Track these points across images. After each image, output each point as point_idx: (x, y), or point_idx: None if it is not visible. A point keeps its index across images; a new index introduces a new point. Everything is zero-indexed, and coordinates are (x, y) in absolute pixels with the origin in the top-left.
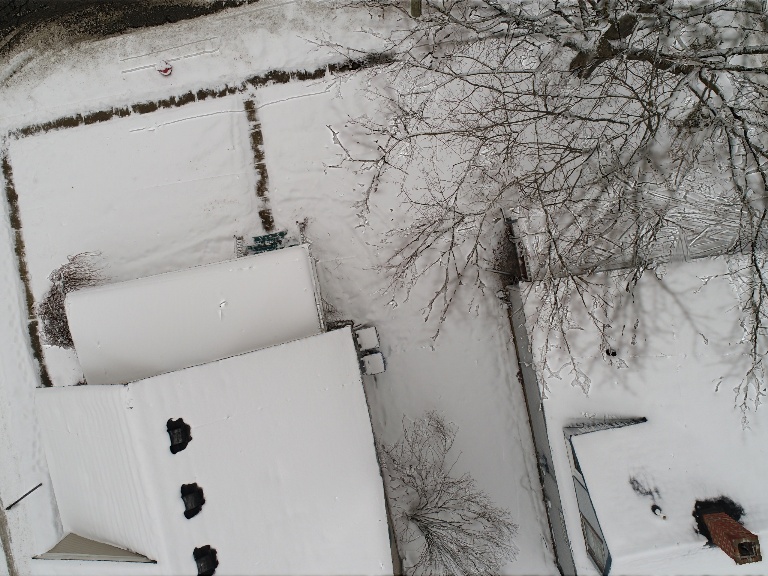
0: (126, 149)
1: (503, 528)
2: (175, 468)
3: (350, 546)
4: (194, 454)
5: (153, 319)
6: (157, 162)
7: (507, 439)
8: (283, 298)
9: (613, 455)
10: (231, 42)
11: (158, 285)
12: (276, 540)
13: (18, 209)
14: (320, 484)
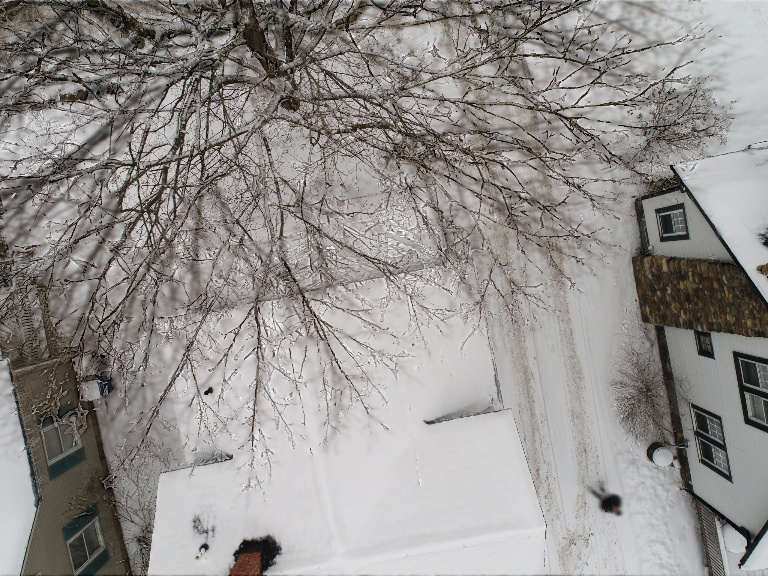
0: None
1: None
2: None
3: None
4: None
5: None
6: None
7: None
8: None
9: (187, 493)
10: None
11: None
12: None
13: None
14: None
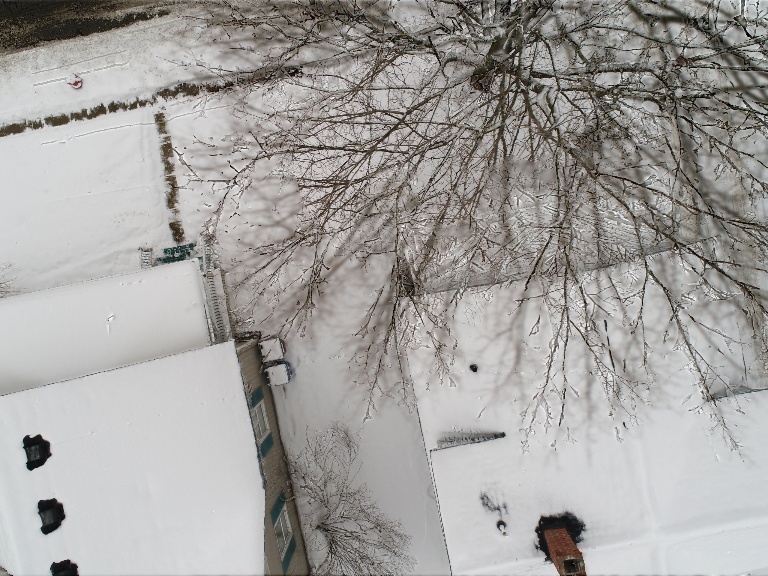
0: (38, 161)
1: (399, 538)
2: (31, 484)
3: (225, 559)
4: (53, 470)
5: (43, 333)
6: (68, 174)
7: (414, 449)
8: (171, 312)
9: (467, 470)
10: (140, 55)
11: (49, 299)
12: (144, 554)
13: None
14: (195, 497)
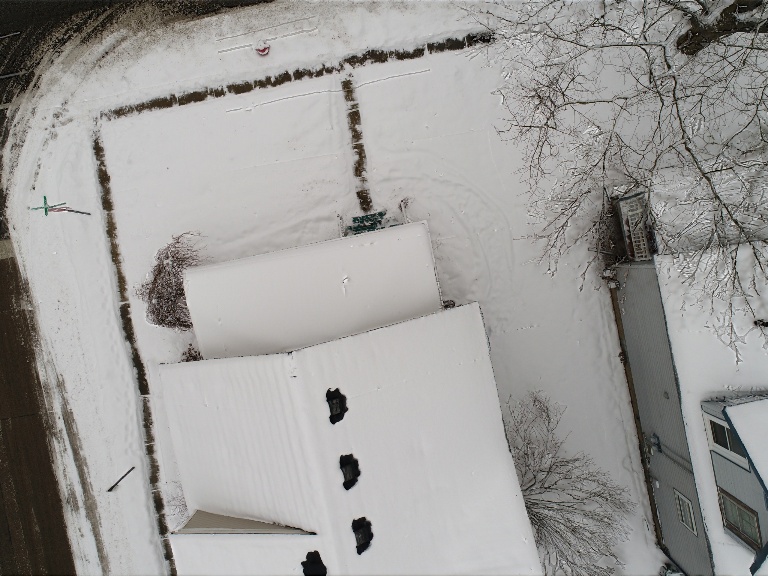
0: (223, 129)
1: None
2: (335, 438)
3: (489, 521)
4: (350, 425)
5: (275, 295)
6: (255, 142)
7: (609, 420)
8: (406, 274)
9: None
10: (330, 21)
11: (278, 261)
12: (422, 514)
13: (110, 191)
14: (458, 459)
